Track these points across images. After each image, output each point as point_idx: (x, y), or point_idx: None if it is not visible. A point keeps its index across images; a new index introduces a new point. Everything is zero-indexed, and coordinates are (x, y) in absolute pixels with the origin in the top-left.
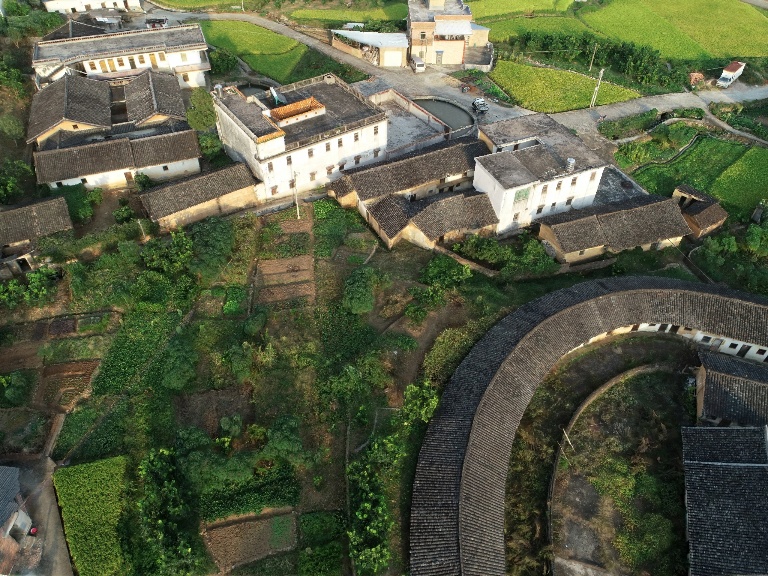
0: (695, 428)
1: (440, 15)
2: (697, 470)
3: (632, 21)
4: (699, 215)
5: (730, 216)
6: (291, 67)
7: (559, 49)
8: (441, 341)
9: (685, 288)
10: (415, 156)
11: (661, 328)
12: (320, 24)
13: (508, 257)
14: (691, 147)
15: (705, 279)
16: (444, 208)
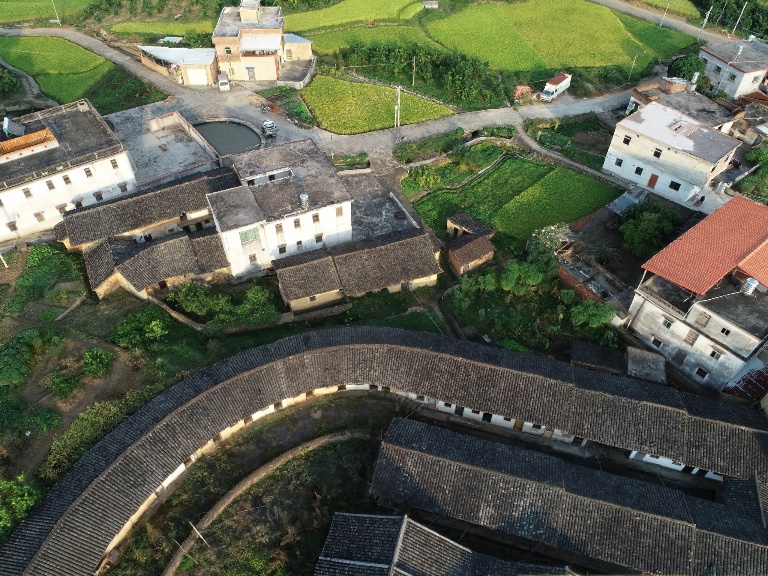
0: (346, 515)
1: (247, 29)
2: (325, 569)
3: (478, 29)
4: (460, 250)
5: (502, 249)
6: (85, 88)
7: (383, 62)
8: (84, 417)
9: (397, 341)
10: (148, 193)
11: (372, 386)
12: (140, 38)
13: (221, 308)
14: (491, 169)
15: (453, 323)
16: (162, 253)
